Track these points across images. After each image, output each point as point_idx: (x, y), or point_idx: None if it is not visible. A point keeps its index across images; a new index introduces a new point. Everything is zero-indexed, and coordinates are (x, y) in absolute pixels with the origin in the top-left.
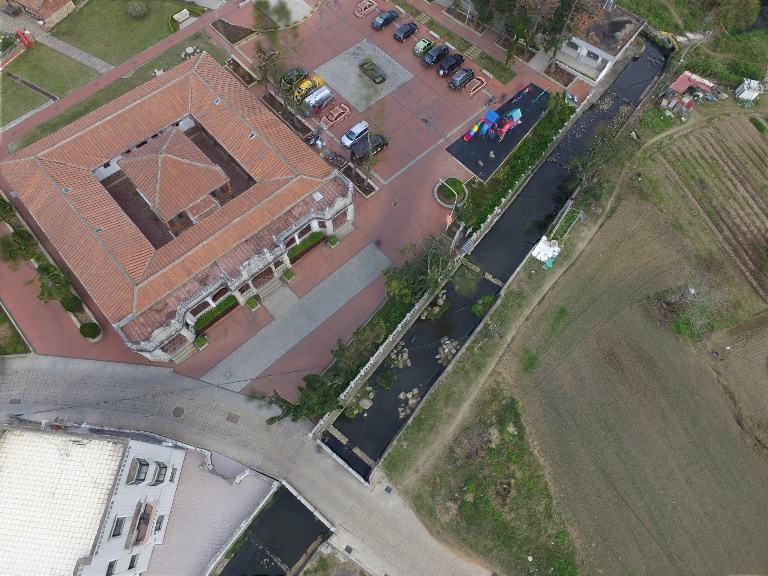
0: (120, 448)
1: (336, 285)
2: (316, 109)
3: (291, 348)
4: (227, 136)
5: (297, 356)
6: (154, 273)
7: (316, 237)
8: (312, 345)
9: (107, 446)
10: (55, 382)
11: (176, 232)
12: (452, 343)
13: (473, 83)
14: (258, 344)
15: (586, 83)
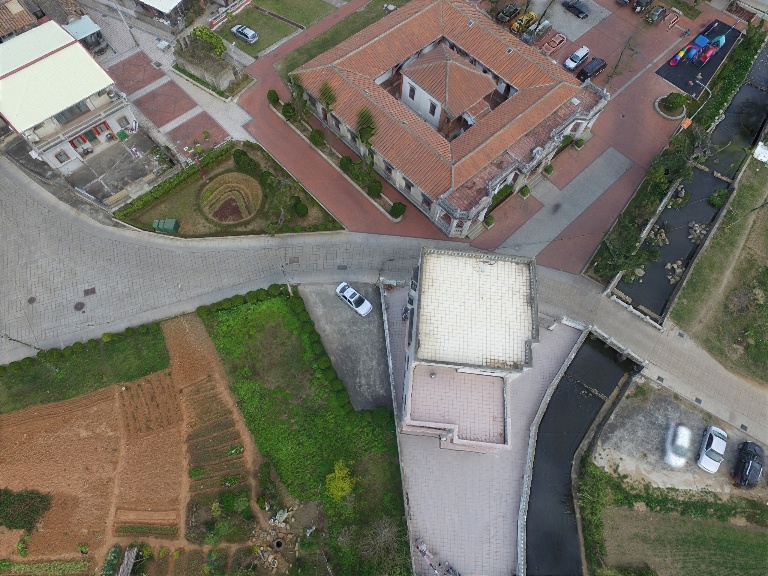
0: (522, 267)
1: (589, 180)
2: (539, 37)
3: (565, 228)
4: (483, 53)
5: (572, 234)
6: (463, 156)
7: (567, 139)
8: (582, 226)
9: (511, 266)
10: (371, 253)
11: (446, 134)
12: (700, 226)
13: (671, 17)
14: (536, 225)
15: (764, 20)
